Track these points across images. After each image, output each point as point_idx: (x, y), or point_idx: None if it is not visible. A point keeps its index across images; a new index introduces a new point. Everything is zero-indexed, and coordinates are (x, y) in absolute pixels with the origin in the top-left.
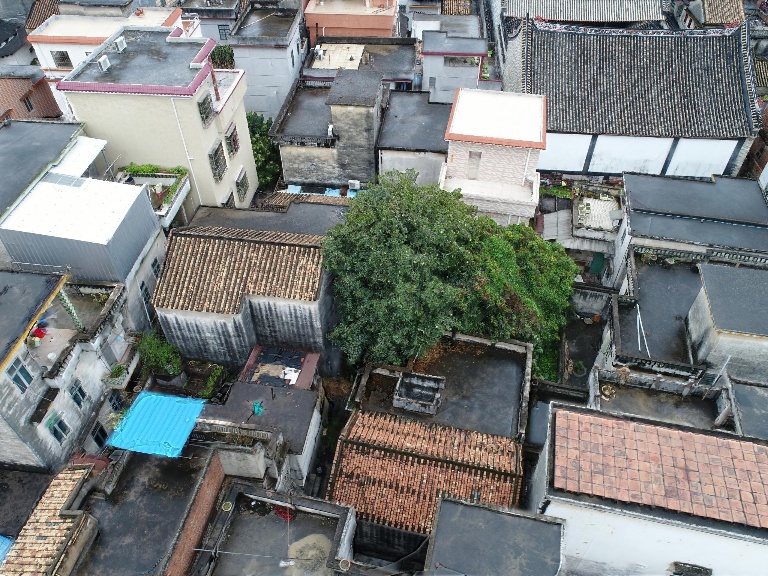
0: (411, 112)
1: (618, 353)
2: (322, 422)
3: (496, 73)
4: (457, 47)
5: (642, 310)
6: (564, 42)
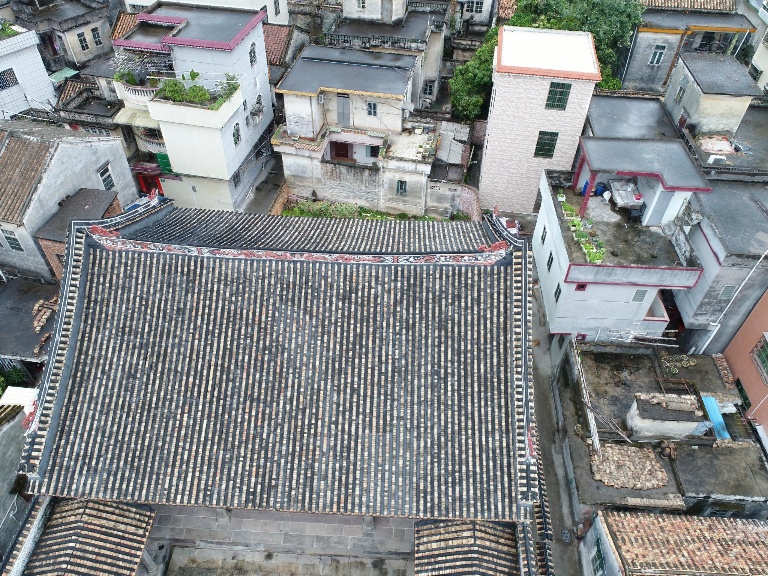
0: None
1: (451, 4)
2: None
3: None
4: (633, 150)
5: None
6: None
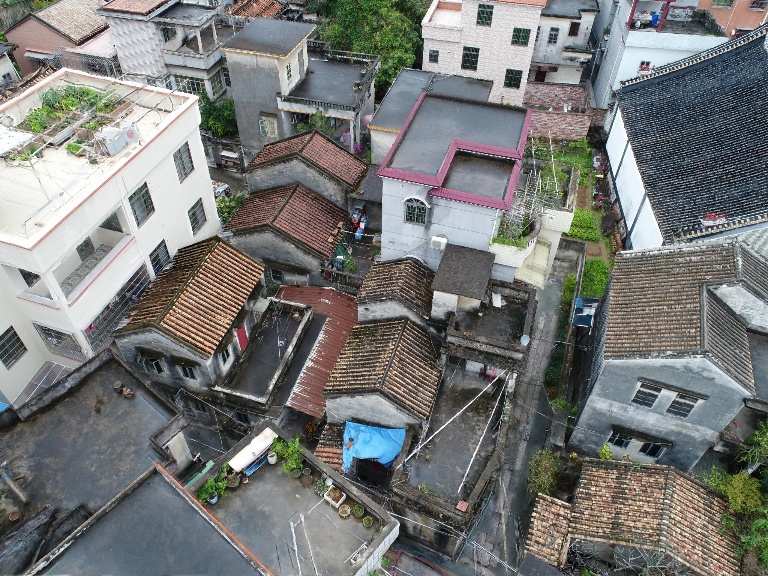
0: (560, 3)
1: None
2: (283, 1)
3: (669, 45)
4: None
5: (322, 62)
6: (759, 70)
